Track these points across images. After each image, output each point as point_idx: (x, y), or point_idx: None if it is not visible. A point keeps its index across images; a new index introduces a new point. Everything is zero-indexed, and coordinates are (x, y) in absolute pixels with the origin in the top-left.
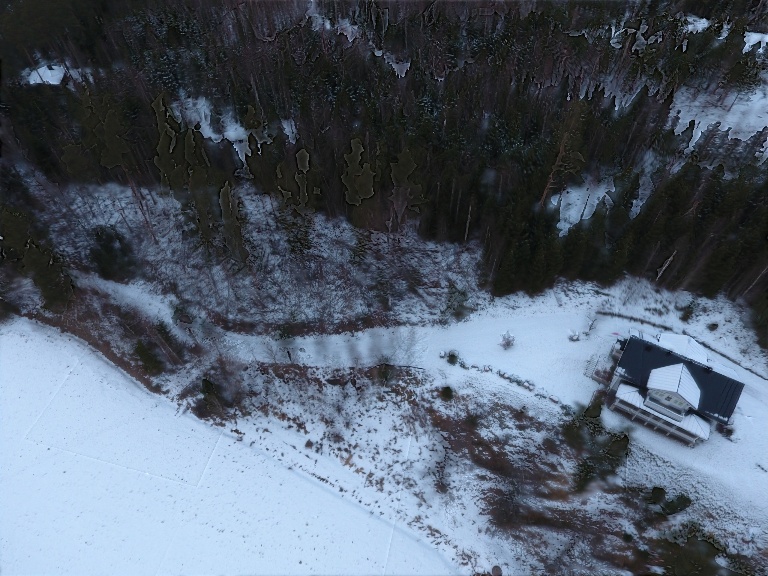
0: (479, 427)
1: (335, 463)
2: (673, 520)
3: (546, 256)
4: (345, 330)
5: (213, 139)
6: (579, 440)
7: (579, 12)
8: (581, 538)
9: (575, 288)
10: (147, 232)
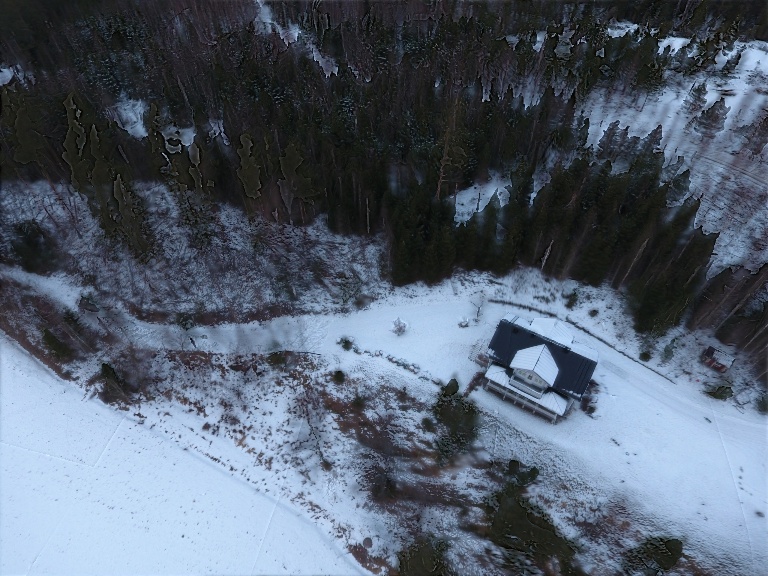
0: (366, 408)
1: (229, 444)
2: (532, 492)
3: (438, 246)
4: (253, 319)
5: None
6: (455, 419)
7: (515, 18)
8: (451, 511)
9: (471, 278)
10: (72, 227)
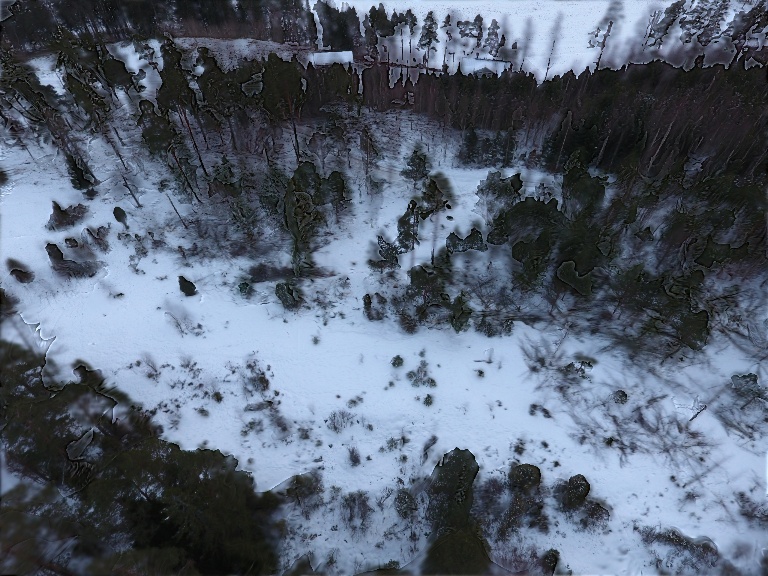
0: None
1: None
2: None
3: None
4: None
5: None
6: None
7: None
8: None
9: None
10: None
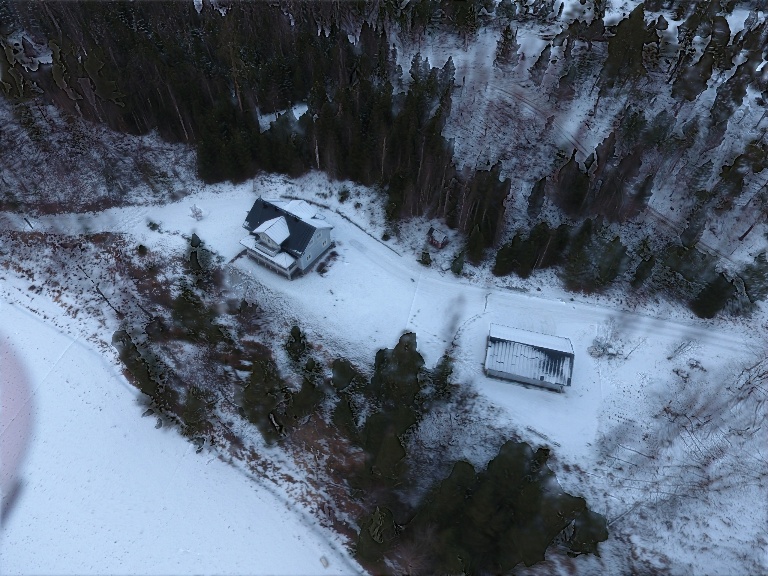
0: (158, 274)
1: (47, 300)
2: (263, 329)
3: (233, 147)
4: (89, 210)
5: (25, 62)
6: (221, 279)
7: None
8: (207, 347)
9: (270, 178)
10: None
